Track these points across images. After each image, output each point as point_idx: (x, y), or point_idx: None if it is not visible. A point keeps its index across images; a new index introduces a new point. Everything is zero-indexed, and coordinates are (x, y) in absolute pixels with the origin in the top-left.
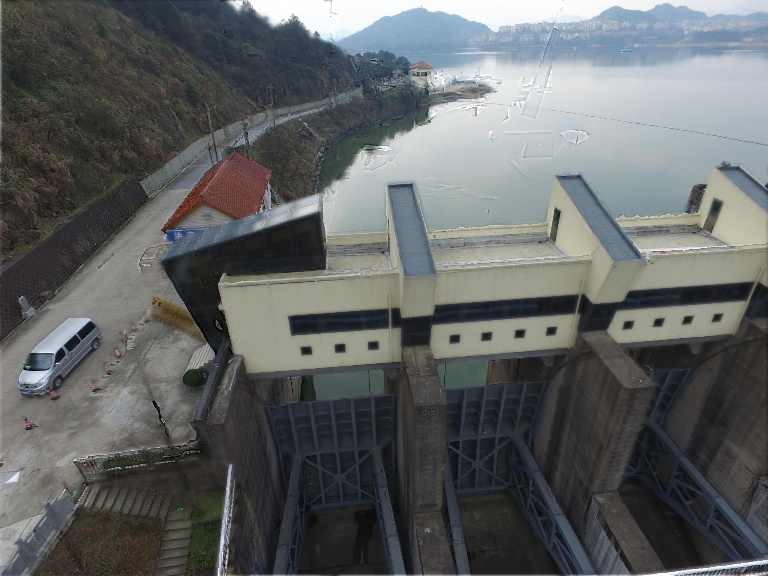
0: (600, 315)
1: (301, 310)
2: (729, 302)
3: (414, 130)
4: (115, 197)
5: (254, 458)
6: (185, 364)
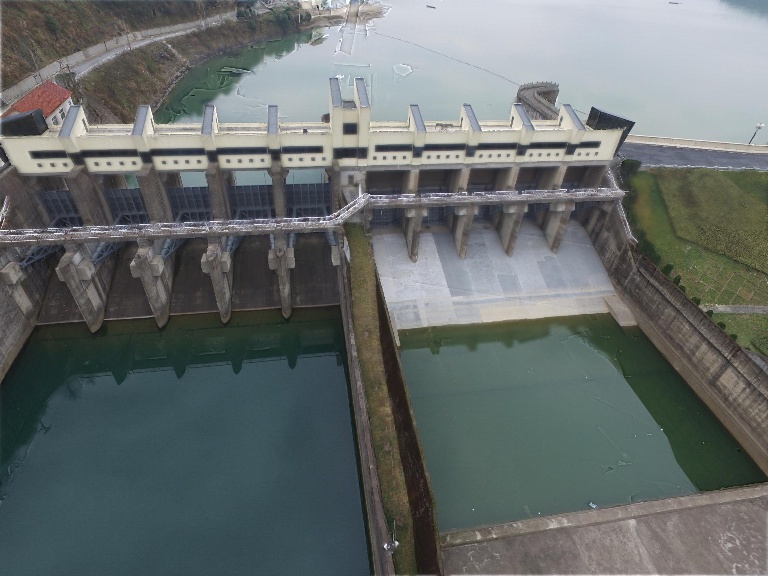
0: (146, 157)
1: (32, 149)
2: (200, 155)
3: (297, 51)
4: None
5: (24, 203)
6: None
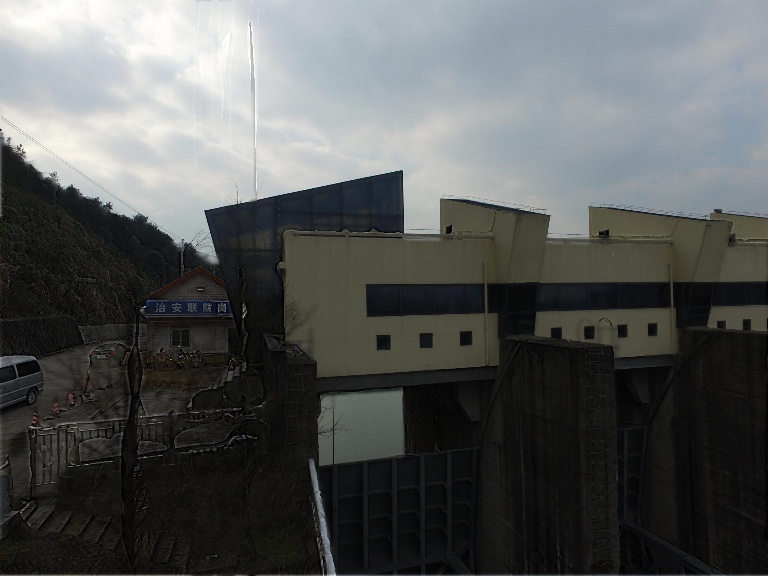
0: (697, 303)
1: (382, 277)
2: None
3: None
4: (51, 325)
5: None
6: (182, 405)
